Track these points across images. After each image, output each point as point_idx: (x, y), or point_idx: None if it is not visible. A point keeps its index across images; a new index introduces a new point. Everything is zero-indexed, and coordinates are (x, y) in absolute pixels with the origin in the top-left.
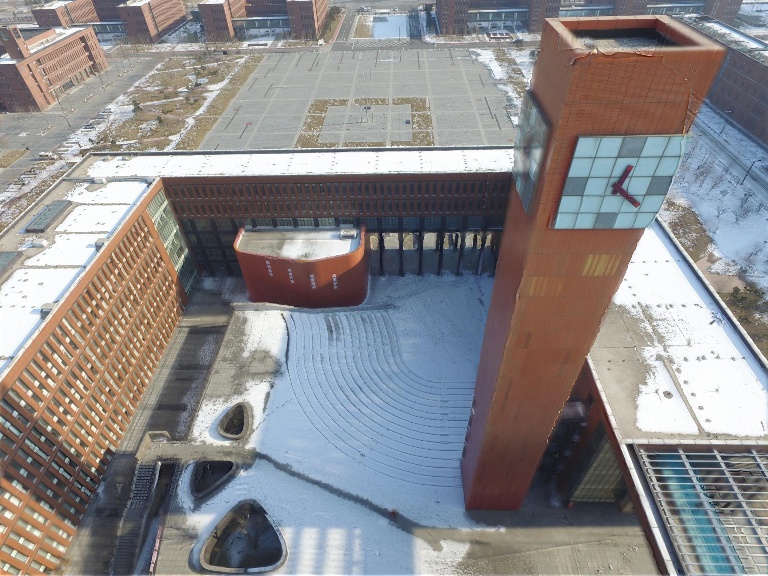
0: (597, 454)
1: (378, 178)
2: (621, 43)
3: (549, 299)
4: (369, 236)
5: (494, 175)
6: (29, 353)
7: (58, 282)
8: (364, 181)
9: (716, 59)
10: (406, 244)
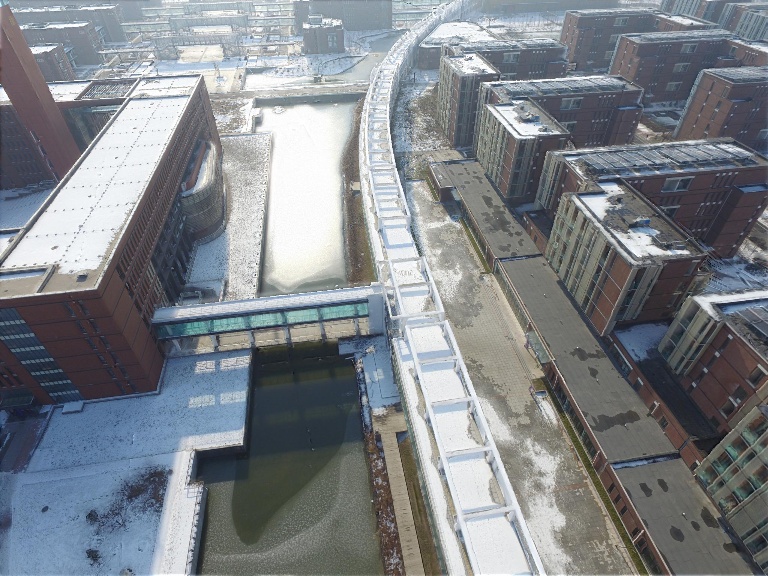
0: (75, 121)
1: None
2: None
3: (14, 38)
4: None
5: None
6: None
7: None
8: None
9: None
10: None
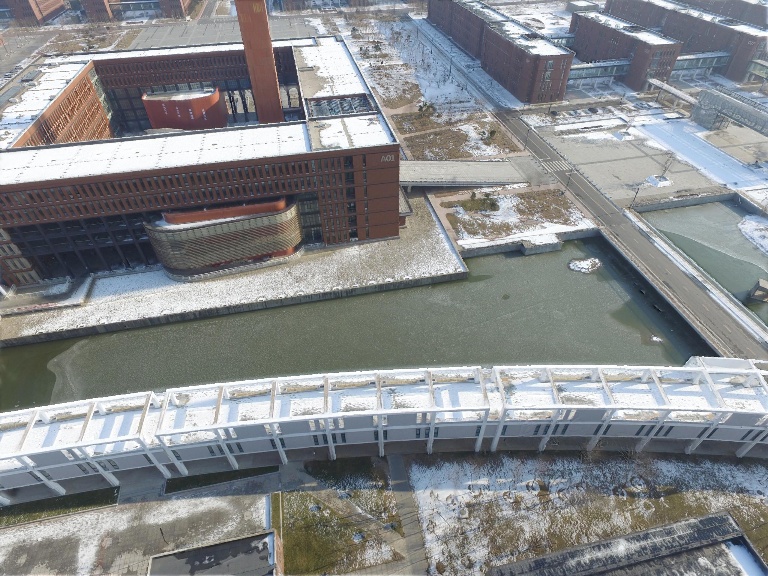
0: None
1: (219, 54)
2: (411, 10)
3: (249, 24)
4: (223, 95)
5: (281, 49)
6: (51, 109)
7: (52, 93)
8: (212, 56)
9: (450, 10)
10: (251, 111)
